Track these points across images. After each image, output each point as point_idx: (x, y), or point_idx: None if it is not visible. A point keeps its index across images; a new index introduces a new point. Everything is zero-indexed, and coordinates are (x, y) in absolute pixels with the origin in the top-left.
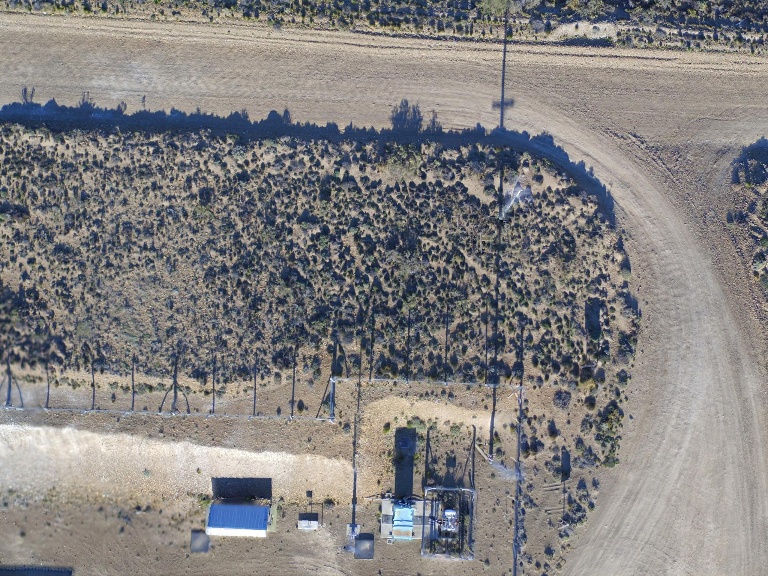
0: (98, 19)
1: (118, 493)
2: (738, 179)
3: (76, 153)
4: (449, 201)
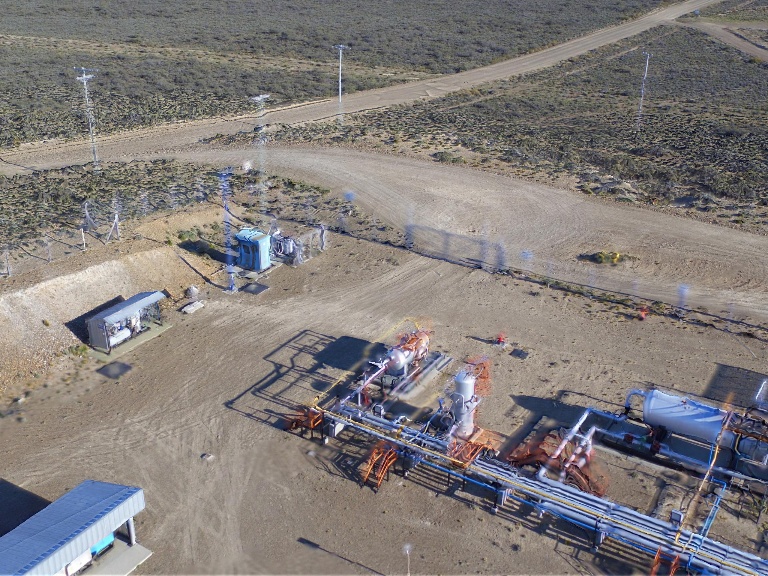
0: None
1: None
2: None
3: None
4: None
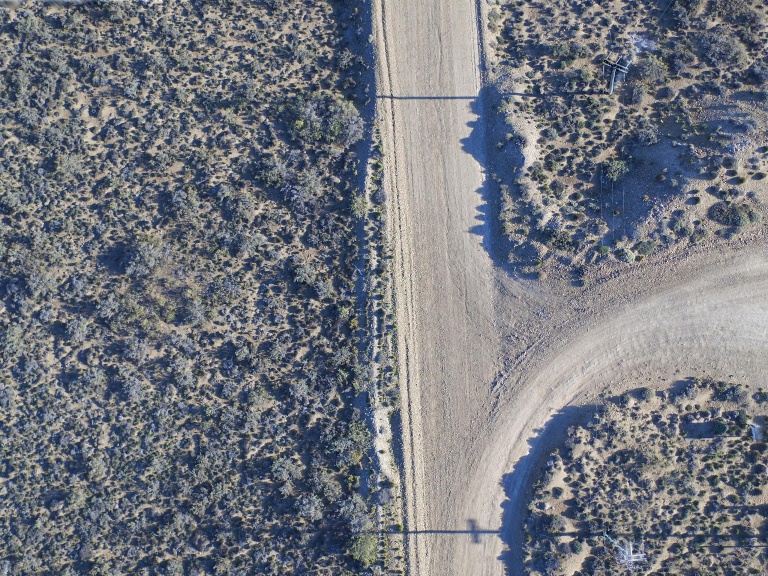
0: None
1: None
2: (533, 274)
3: None
4: None
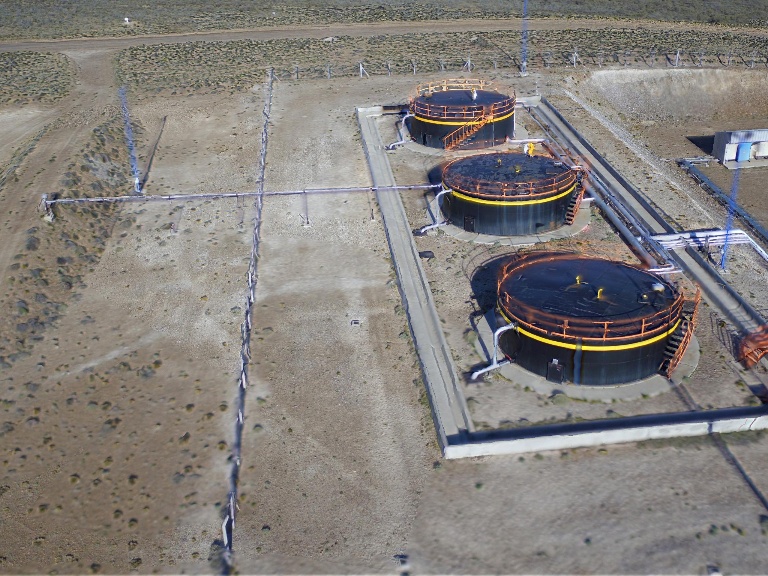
0: (622, 21)
1: (760, 112)
2: None
3: (645, 32)
4: None
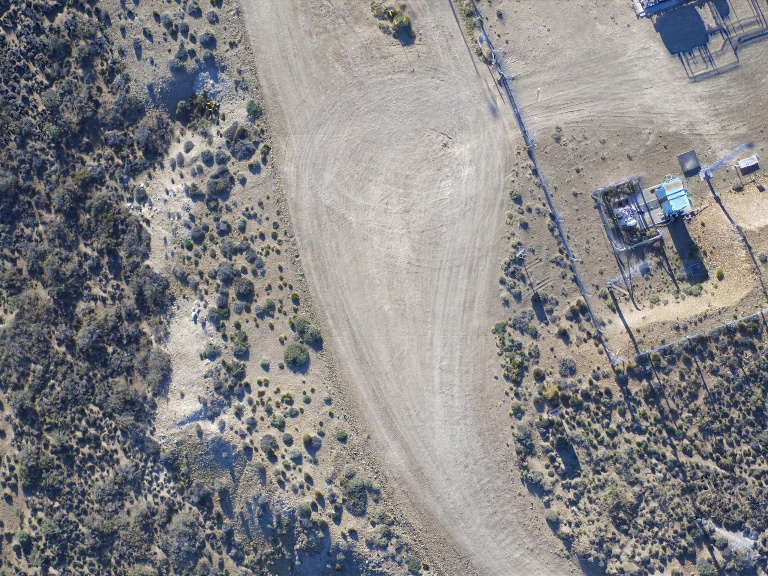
0: None
1: None
2: None
3: None
4: (759, 516)
